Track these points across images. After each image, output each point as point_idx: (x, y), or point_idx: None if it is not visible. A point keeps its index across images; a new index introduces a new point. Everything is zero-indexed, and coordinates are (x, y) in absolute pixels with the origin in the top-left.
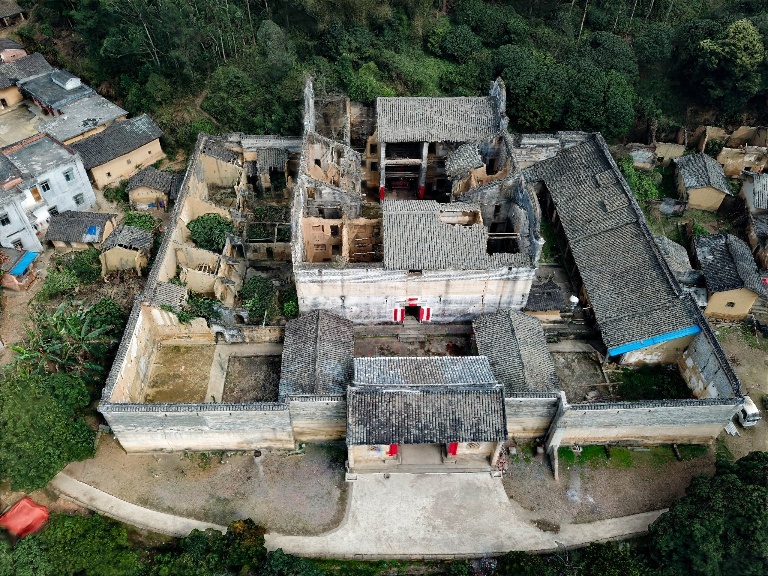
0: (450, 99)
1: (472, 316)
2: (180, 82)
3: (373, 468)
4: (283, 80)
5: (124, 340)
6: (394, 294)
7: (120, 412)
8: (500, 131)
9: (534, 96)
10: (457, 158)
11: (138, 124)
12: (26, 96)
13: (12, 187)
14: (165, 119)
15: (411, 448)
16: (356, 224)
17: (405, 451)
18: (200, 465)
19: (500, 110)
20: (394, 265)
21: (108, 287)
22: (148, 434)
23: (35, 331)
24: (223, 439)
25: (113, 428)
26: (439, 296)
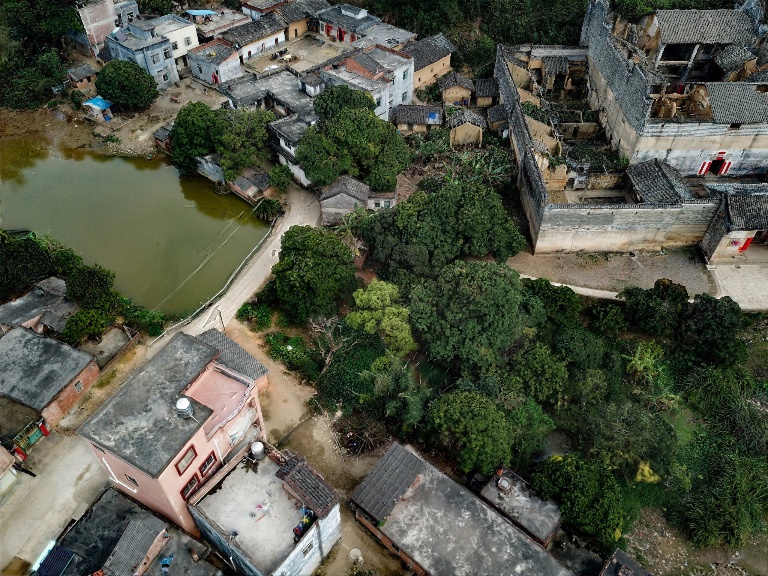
0: (714, 11)
1: (761, 170)
2: (463, 8)
3: (726, 262)
4: (554, 4)
5: (537, 168)
6: (709, 148)
7: (558, 210)
8: (763, 33)
9: (764, 15)
10: (727, 55)
11: (438, 40)
12: (309, 28)
13: (378, 79)
14: (455, 37)
15: (749, 251)
16: (670, 98)
17: (745, 252)
18: (592, 261)
19: (759, 18)
20: (722, 120)
21: (460, 154)
22: (563, 233)
23: (452, 169)
24: (614, 240)
25: (542, 227)
26: (743, 150)
